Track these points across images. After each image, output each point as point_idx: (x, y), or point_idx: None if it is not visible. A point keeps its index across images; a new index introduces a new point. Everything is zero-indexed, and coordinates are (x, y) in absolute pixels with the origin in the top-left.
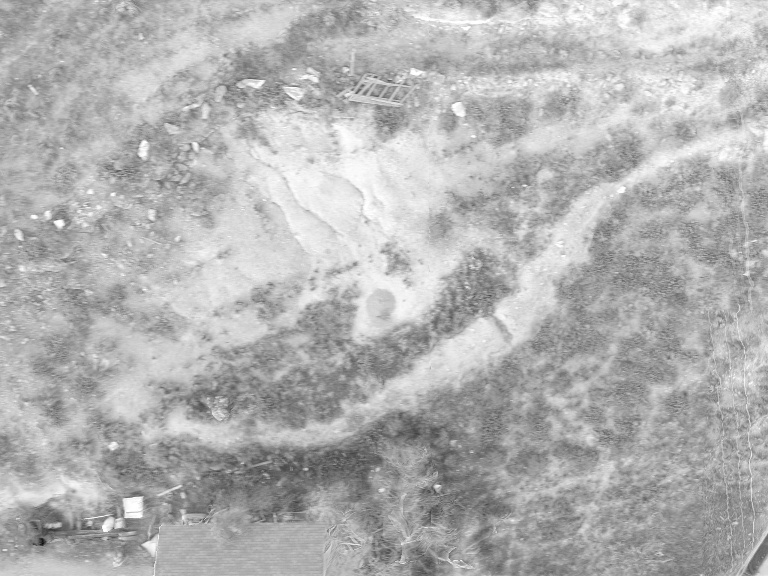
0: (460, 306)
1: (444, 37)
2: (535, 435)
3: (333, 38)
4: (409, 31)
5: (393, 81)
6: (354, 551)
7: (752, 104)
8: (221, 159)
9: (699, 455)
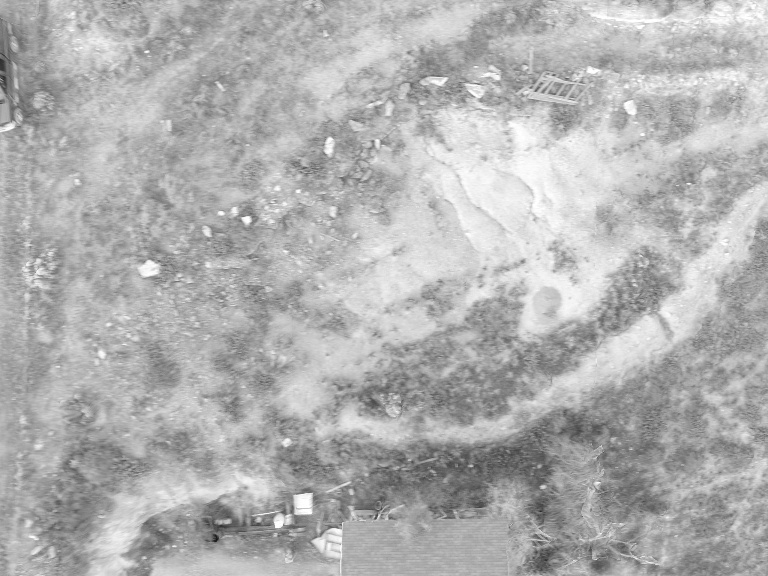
0: (626, 304)
1: (618, 35)
2: (693, 432)
3: (512, 36)
4: (585, 29)
5: (570, 79)
6: (517, 548)
7: None
8: (399, 156)
9: None
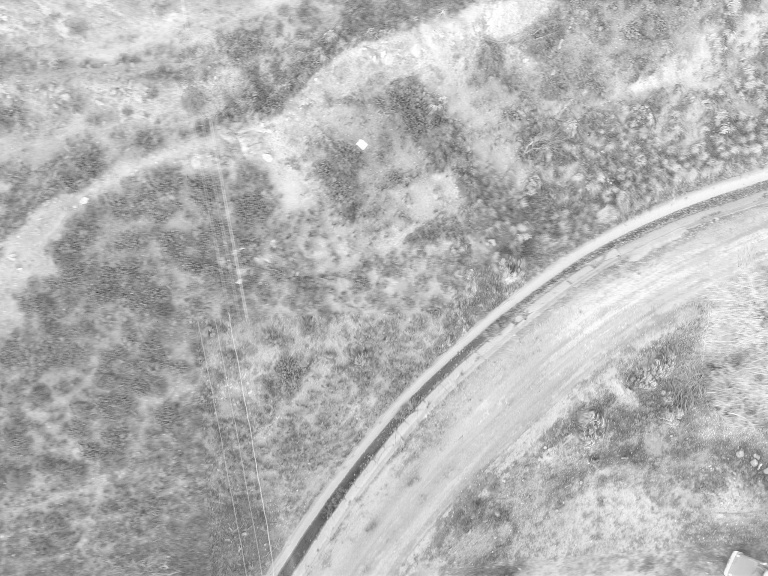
0: None
1: None
2: (13, 450)
3: None
4: None
5: None
6: None
7: (220, 111)
8: None
9: (199, 466)
